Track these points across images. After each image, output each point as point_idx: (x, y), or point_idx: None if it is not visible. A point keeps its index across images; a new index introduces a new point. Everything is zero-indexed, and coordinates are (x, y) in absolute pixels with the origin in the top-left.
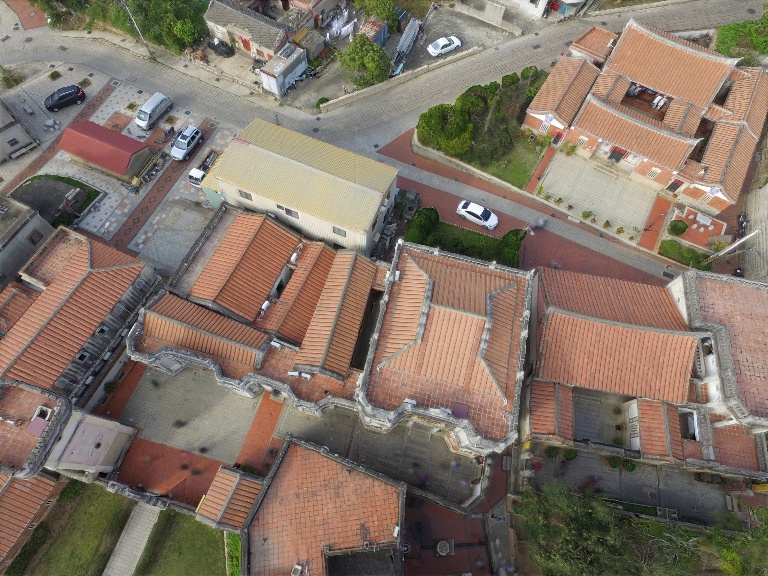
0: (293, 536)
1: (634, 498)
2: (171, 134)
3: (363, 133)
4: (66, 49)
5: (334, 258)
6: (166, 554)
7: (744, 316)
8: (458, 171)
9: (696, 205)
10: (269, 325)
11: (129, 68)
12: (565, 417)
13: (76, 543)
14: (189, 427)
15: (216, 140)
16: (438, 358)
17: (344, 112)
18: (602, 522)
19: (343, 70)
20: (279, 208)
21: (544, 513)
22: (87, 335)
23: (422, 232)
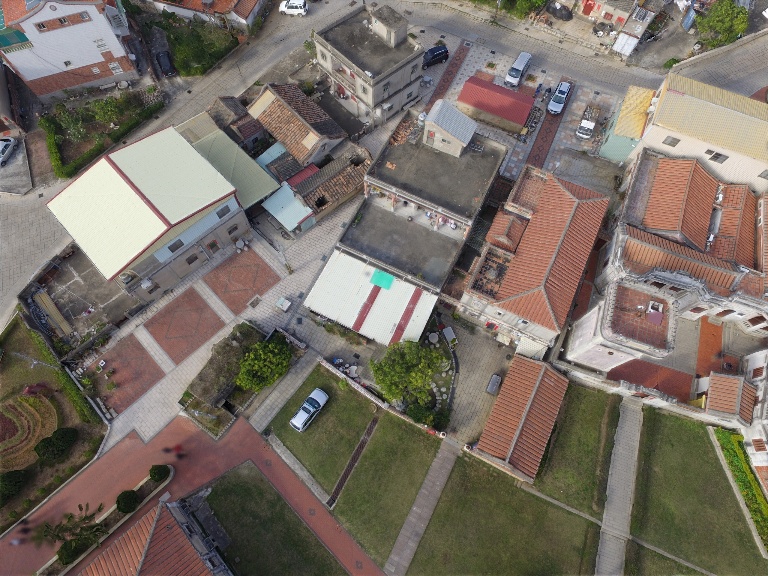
0: None
1: None
2: None
3: None
4: (411, 13)
5: (753, 200)
6: (660, 445)
7: None
8: None
9: None
10: (720, 255)
11: (475, 31)
12: None
13: (579, 433)
14: None
15: (579, 96)
16: None
17: (691, 72)
18: None
19: (677, 33)
20: (706, 153)
21: None
22: (586, 256)
23: None
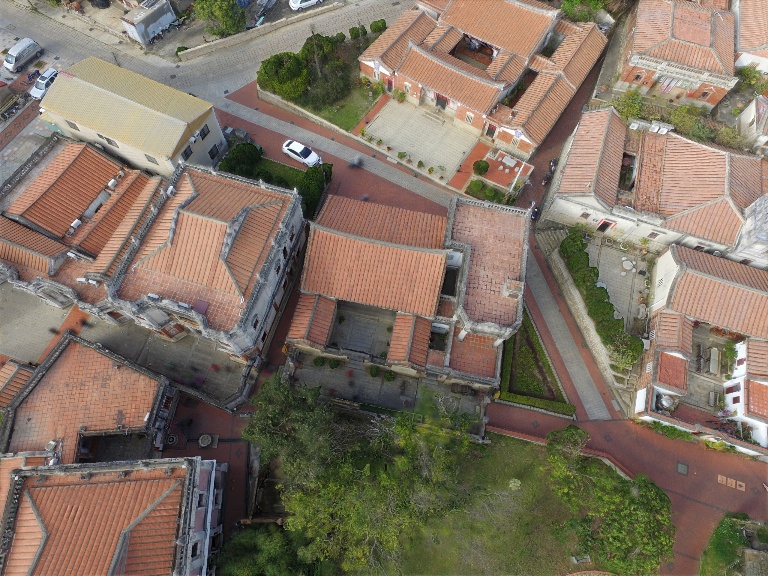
0: (55, 418)
1: (390, 405)
2: (36, 77)
3: (216, 80)
4: None
5: None
6: None
7: (497, 239)
8: (296, 115)
9: (511, 150)
10: (75, 240)
11: (11, 17)
12: (321, 325)
13: None
14: (0, 331)
15: None
16: (186, 260)
17: (203, 61)
18: (311, 406)
19: None
20: (100, 137)
21: (270, 401)
22: None
23: (229, 162)
